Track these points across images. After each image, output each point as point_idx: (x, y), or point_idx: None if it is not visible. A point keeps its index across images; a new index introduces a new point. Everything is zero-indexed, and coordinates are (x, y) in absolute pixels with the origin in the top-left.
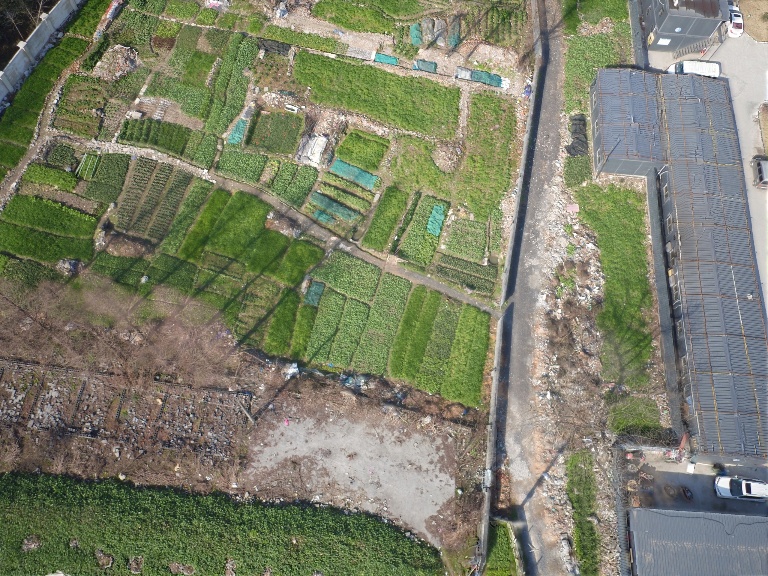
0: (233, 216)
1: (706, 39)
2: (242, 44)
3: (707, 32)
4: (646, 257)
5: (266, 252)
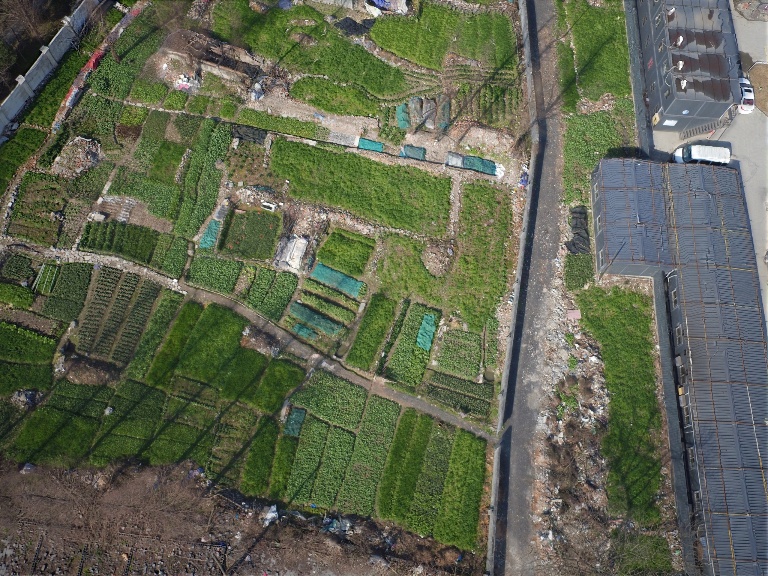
0: (205, 333)
1: (716, 121)
2: (214, 132)
3: (717, 114)
4: (654, 370)
5: (242, 375)
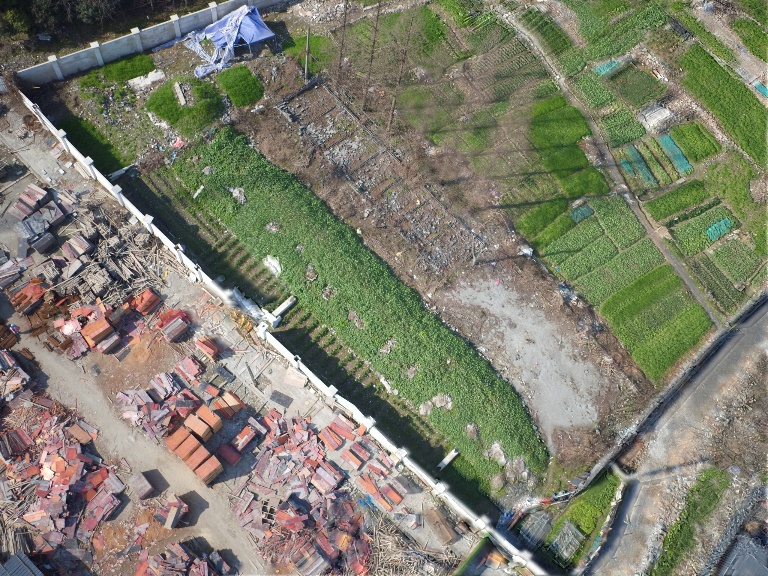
0: (557, 120)
1: None
2: (649, 8)
3: None
4: None
5: (565, 160)
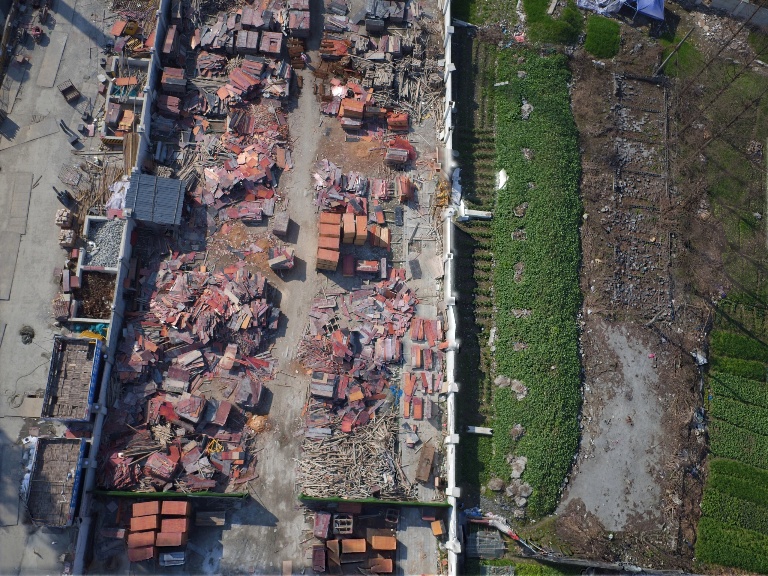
0: None
1: None
2: None
3: None
4: None
5: None
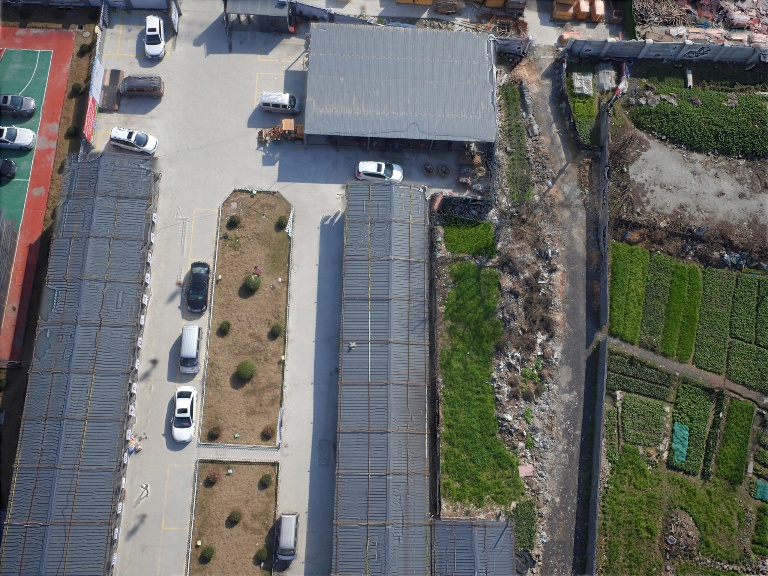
0: None
1: None
2: None
3: None
4: (443, 409)
5: None
